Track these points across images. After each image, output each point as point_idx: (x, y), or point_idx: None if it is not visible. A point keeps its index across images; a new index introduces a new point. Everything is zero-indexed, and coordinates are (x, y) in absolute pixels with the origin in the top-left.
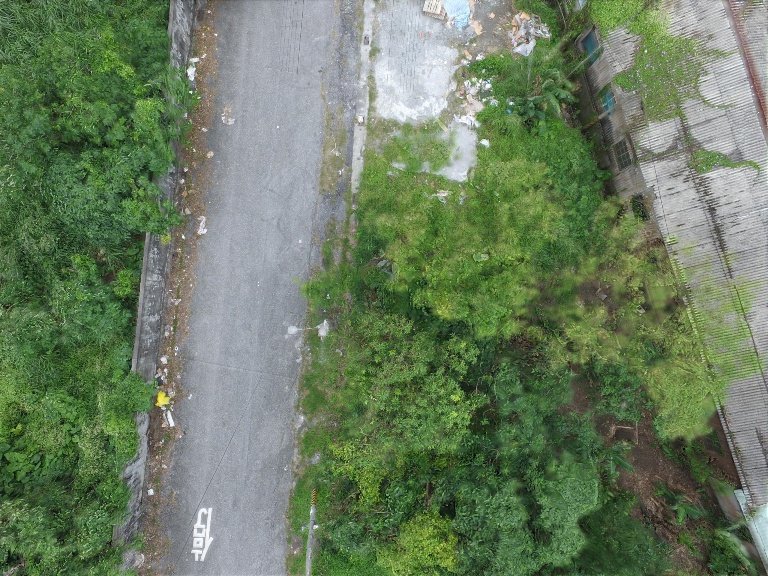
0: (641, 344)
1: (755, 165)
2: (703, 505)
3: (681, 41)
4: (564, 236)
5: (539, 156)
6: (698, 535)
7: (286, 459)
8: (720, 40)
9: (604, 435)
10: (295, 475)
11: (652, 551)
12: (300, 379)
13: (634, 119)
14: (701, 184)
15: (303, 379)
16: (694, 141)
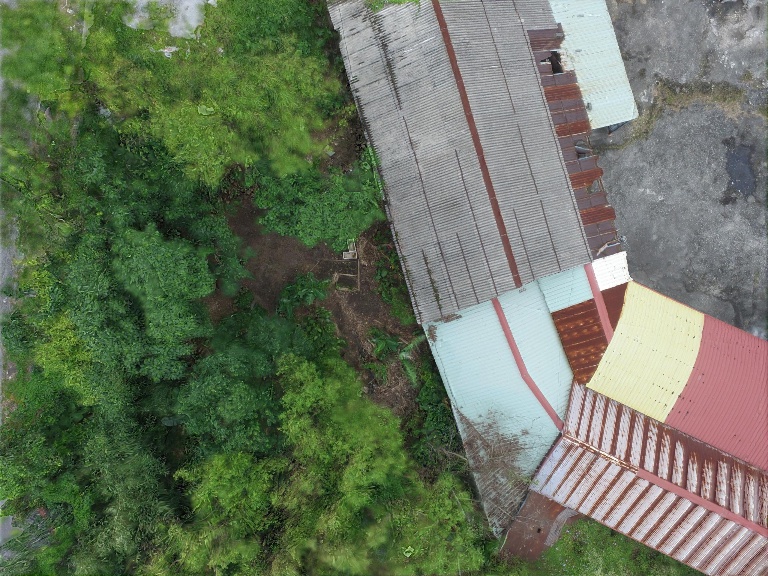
0: None
1: None
2: (420, 348)
3: None
4: (276, 86)
5: (258, 13)
6: None
7: None
8: None
9: None
10: (14, 307)
11: (367, 389)
12: (23, 219)
13: None
14: (375, 22)
15: (25, 219)
16: None
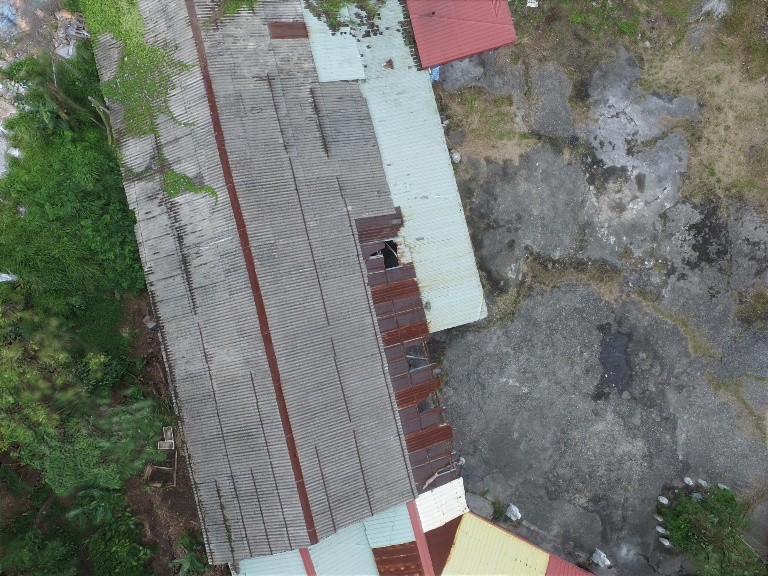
0: None
1: (213, 191)
2: None
3: (152, 49)
4: (75, 258)
5: (62, 169)
6: None
7: None
8: (185, 50)
9: (139, 475)
10: None
11: None
12: None
13: (118, 134)
14: (171, 209)
15: None
16: (165, 161)
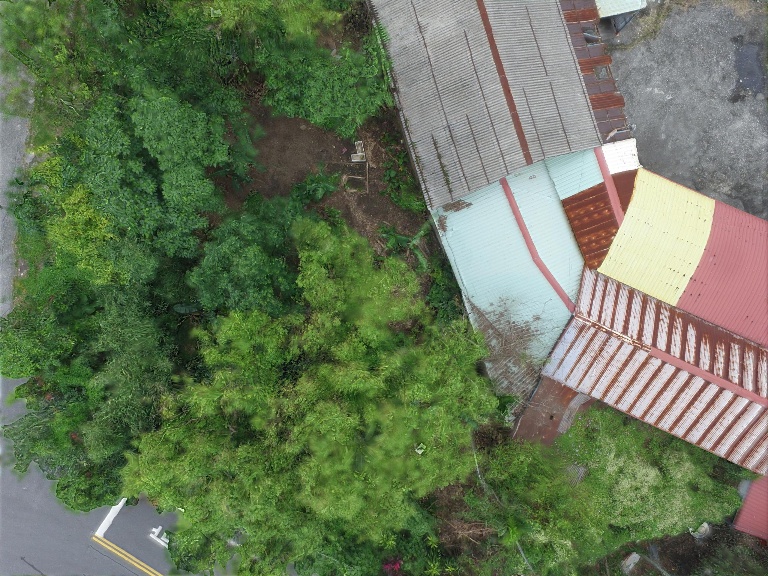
0: (372, 99)
1: None
2: (429, 249)
3: None
4: None
5: None
6: (422, 275)
7: (16, 191)
8: None
9: None
10: None
11: (377, 289)
12: (32, 118)
13: None
14: None
15: (35, 119)
16: None
